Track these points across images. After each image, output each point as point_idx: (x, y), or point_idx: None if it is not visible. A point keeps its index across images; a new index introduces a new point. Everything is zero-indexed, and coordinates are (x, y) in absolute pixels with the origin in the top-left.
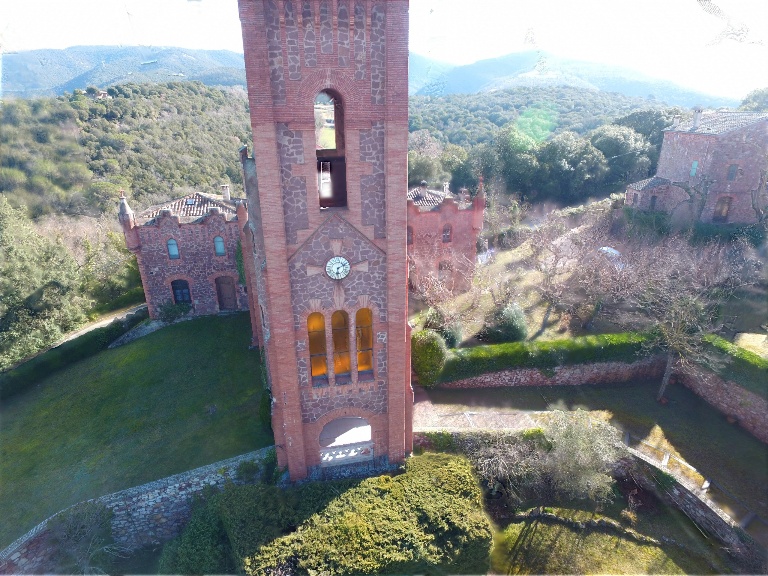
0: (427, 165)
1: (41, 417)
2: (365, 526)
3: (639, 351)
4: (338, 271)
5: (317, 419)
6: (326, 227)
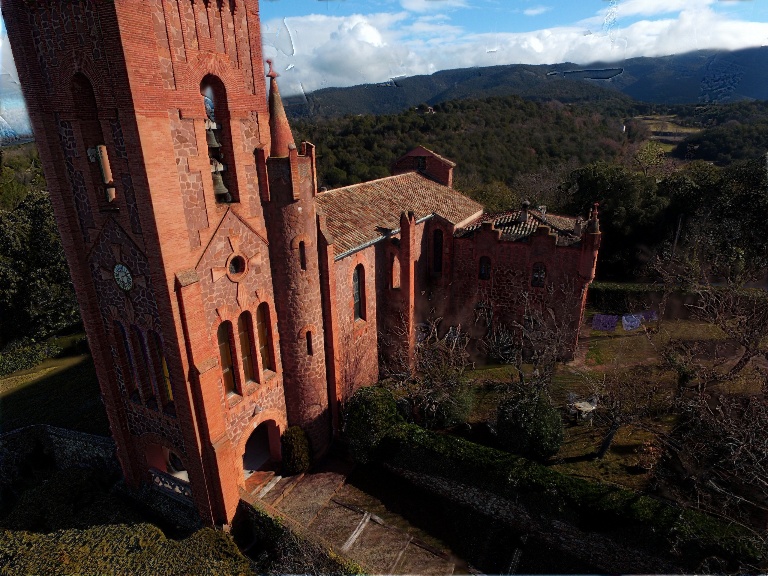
0: (624, 185)
1: None
2: (74, 571)
3: (688, 572)
4: (123, 281)
5: (141, 435)
6: (107, 229)
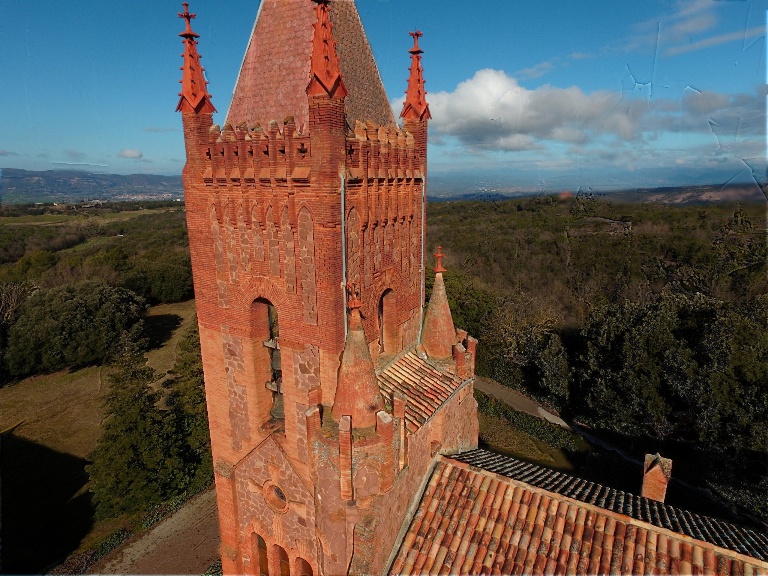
0: None
1: None
2: None
3: None
4: None
5: None
6: None
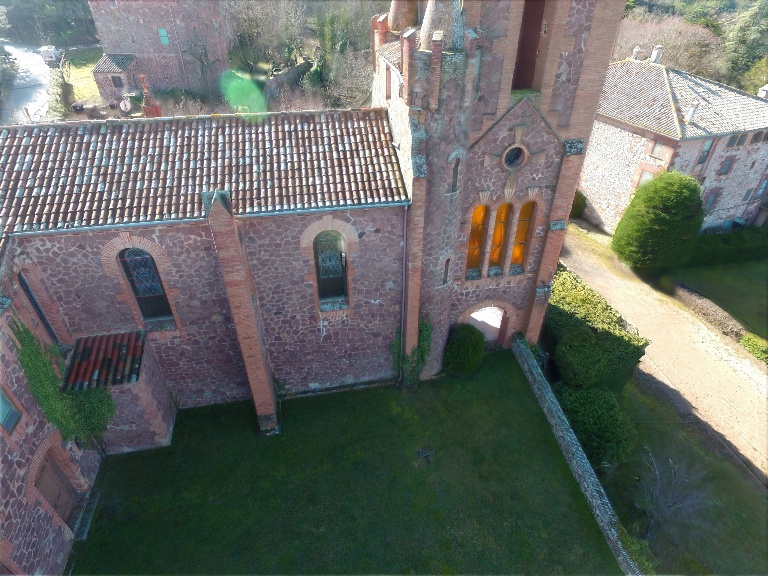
0: None
1: None
2: None
3: None
4: None
5: None
6: None
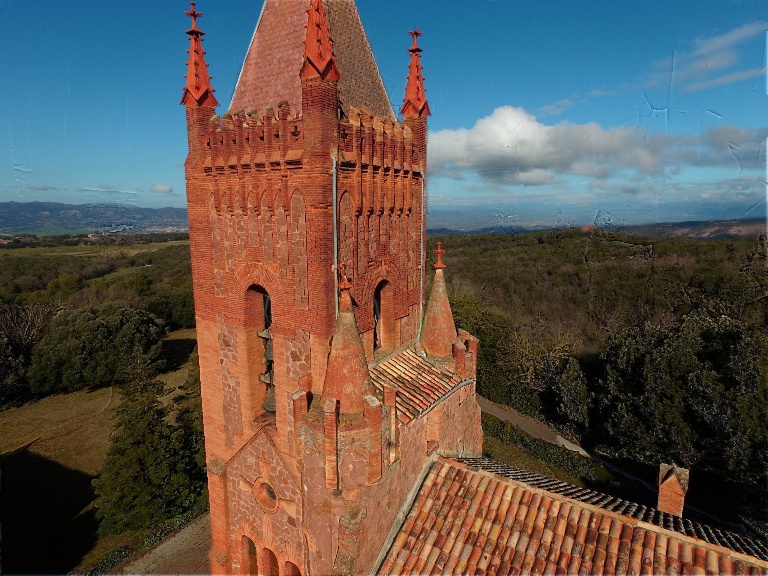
0: None
1: None
2: None
3: None
4: None
5: None
6: None
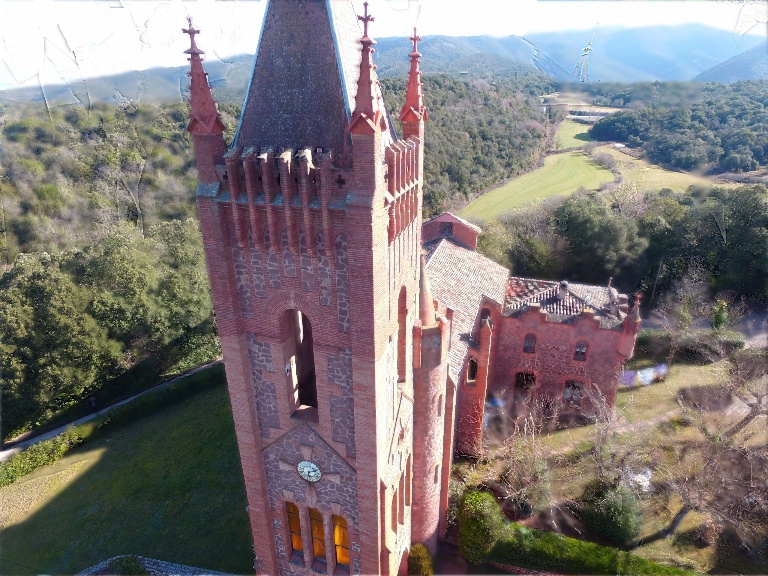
0: (613, 230)
1: (171, 437)
2: None
3: None
4: (309, 474)
5: None
6: (297, 432)
